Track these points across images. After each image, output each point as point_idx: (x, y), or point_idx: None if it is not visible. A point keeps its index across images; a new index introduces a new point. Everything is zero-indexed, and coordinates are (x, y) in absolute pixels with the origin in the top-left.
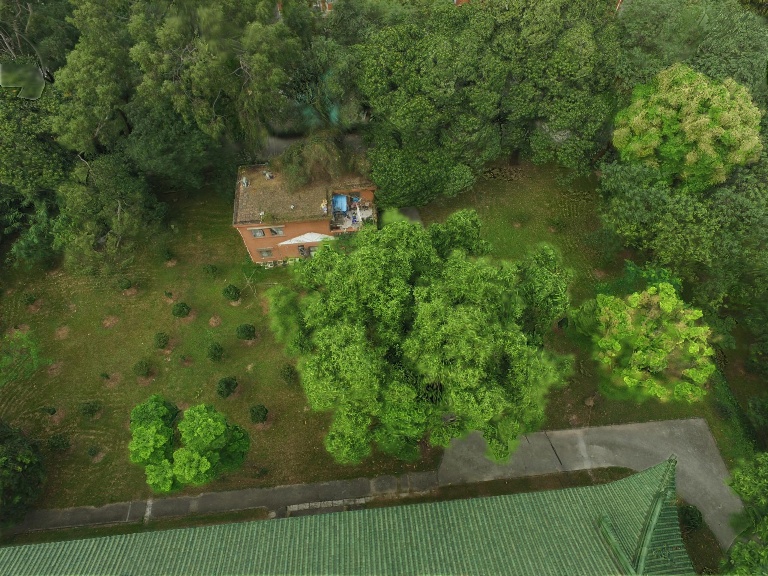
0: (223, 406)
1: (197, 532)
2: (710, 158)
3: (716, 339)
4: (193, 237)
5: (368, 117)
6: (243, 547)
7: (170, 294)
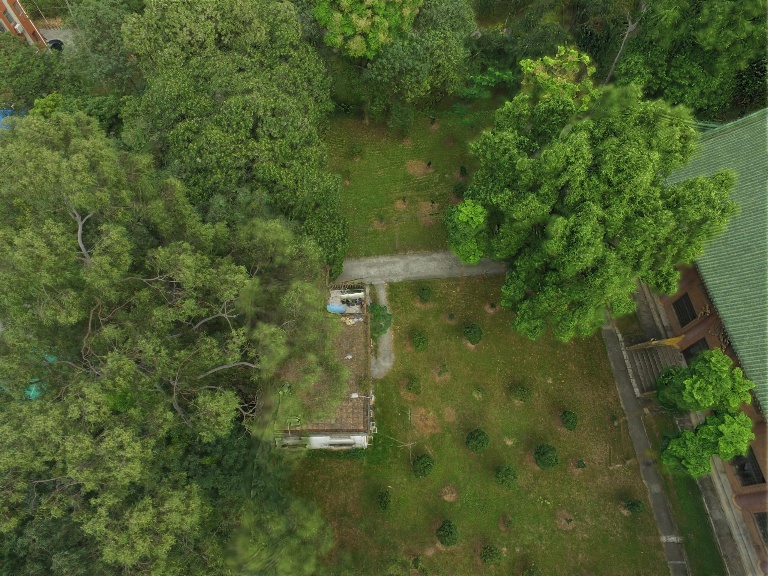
0: (555, 469)
1: (763, 398)
2: (419, 1)
3: (482, 93)
4: (307, 550)
5: (290, 220)
6: (764, 355)
7: (416, 561)
